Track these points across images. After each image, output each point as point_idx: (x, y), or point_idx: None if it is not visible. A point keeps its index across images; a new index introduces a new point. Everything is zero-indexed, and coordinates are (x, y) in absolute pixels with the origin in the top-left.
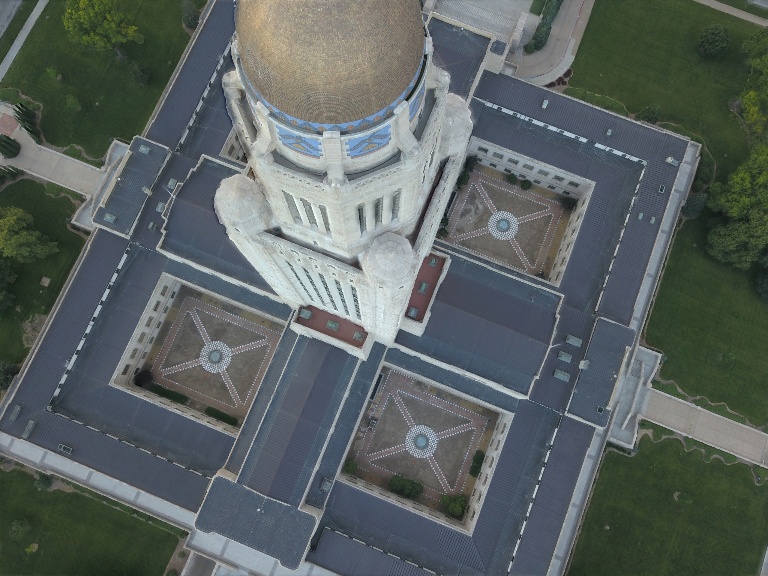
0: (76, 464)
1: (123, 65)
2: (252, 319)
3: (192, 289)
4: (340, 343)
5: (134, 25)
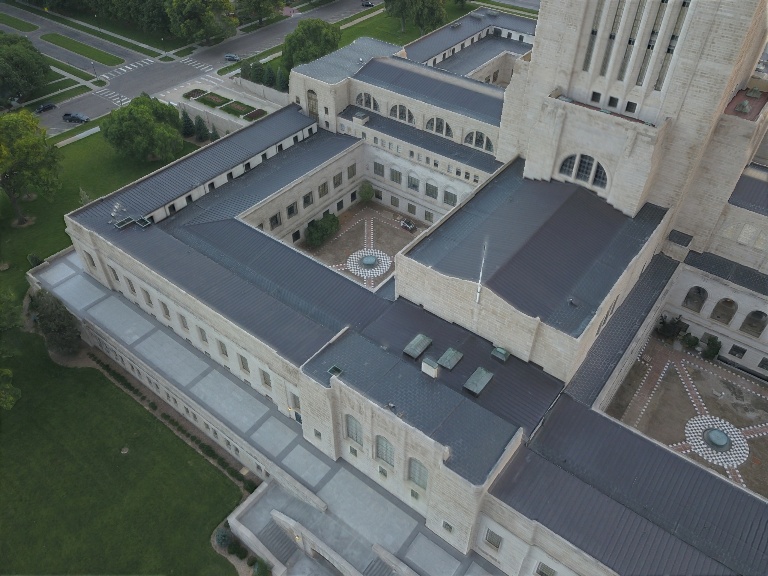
0: None
1: None
2: None
3: None
4: None
5: None
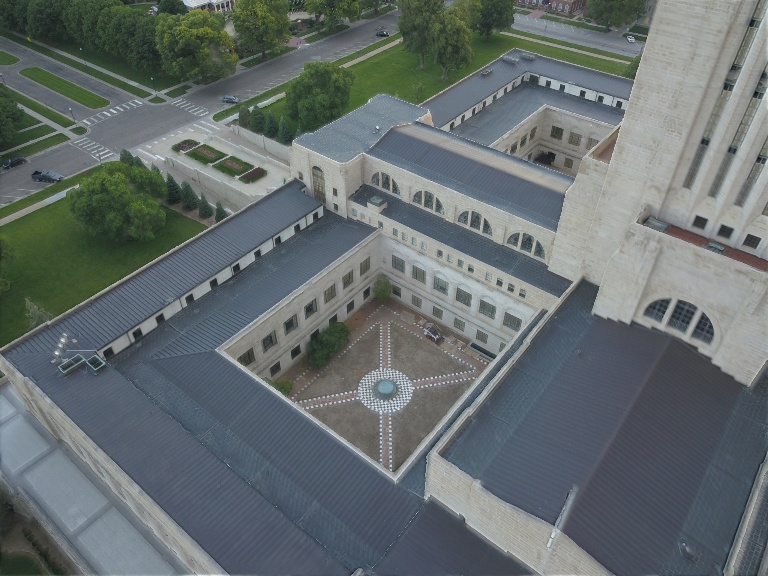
0: None
1: None
2: None
3: None
4: None
5: None
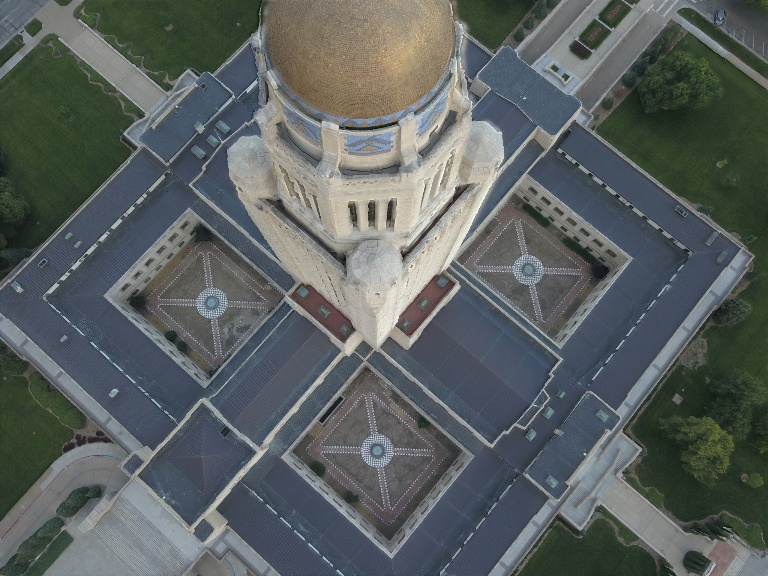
0: None
1: None
2: None
3: None
4: None
5: None
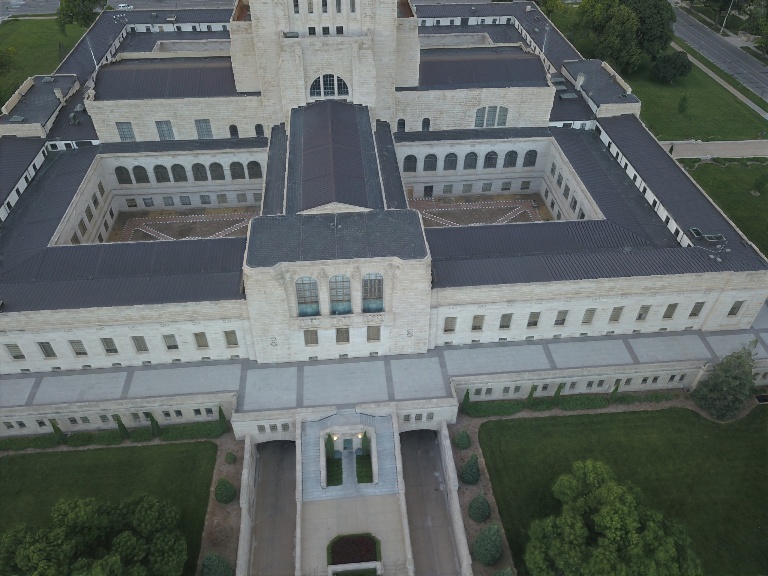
0: (3, 391)
1: (0, 112)
2: (221, 212)
3: (134, 212)
4: (343, 41)
5: (8, 92)
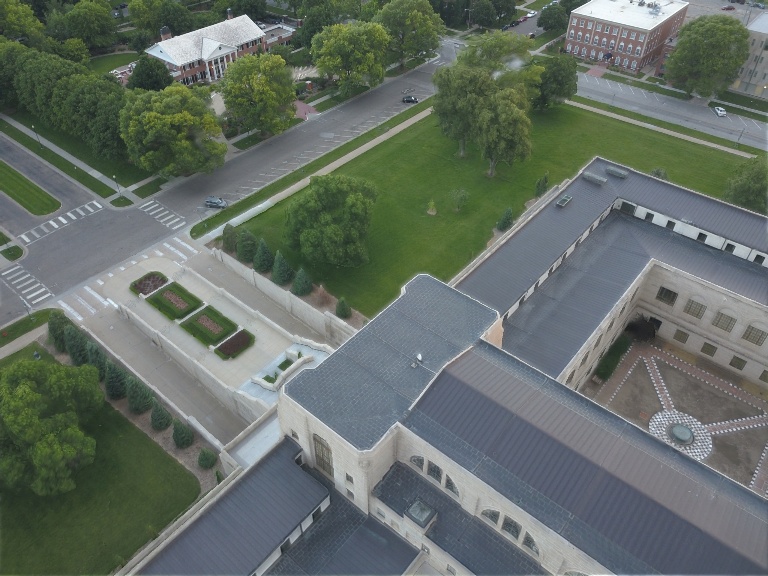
0: None
1: None
2: None
3: None
4: None
5: None
